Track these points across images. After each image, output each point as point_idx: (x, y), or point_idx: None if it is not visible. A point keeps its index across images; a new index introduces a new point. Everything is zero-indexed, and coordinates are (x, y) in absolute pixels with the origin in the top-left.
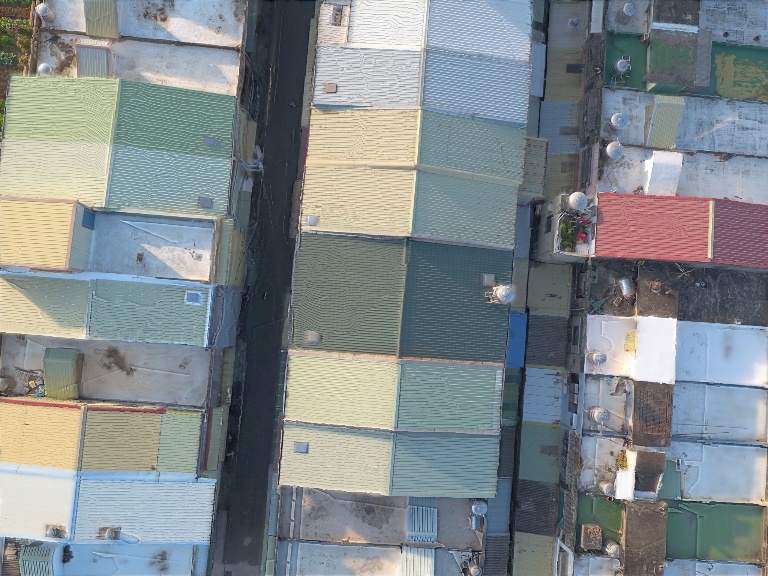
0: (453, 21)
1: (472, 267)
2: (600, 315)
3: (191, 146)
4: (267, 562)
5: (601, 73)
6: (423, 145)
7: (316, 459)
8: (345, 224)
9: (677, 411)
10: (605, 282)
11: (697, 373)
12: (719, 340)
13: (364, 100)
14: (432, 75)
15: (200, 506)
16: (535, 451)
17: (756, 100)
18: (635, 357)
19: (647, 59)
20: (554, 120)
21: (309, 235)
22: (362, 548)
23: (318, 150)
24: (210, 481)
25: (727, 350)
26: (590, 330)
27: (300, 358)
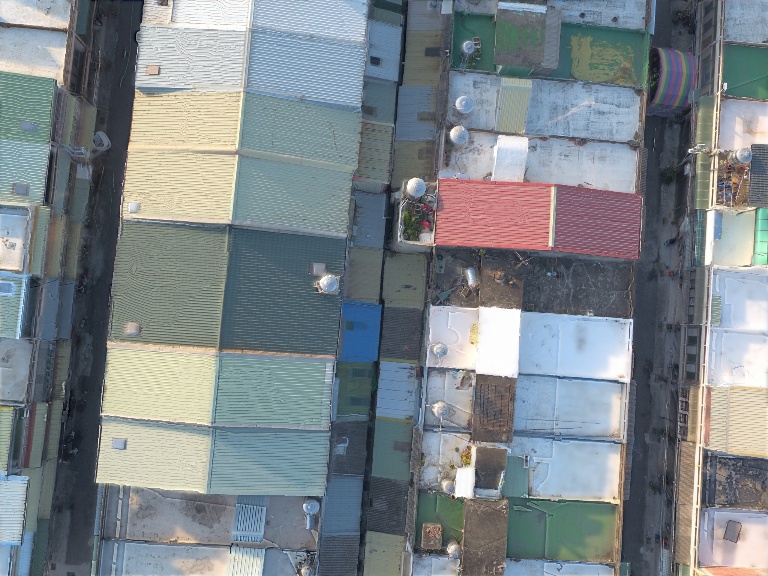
0: (282, 0)
1: (301, 256)
2: (445, 306)
3: (6, 130)
4: (93, 563)
5: (449, 55)
6: (245, 129)
7: (134, 456)
8: (164, 211)
9: (526, 406)
10: (452, 272)
11: (548, 366)
12: (571, 332)
13: (187, 82)
14: (258, 56)
15: (11, 505)
16: (388, 447)
17: (613, 83)
18: (477, 349)
19: (495, 40)
20: (412, 105)
21: (131, 223)
22: (192, 548)
23: (141, 134)
24: (22, 479)
25: (580, 342)
26: (436, 322)
27: (116, 350)
